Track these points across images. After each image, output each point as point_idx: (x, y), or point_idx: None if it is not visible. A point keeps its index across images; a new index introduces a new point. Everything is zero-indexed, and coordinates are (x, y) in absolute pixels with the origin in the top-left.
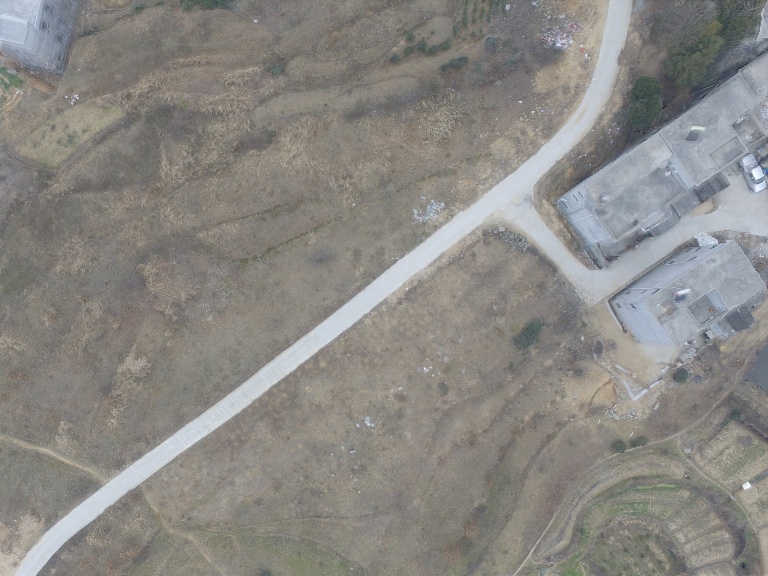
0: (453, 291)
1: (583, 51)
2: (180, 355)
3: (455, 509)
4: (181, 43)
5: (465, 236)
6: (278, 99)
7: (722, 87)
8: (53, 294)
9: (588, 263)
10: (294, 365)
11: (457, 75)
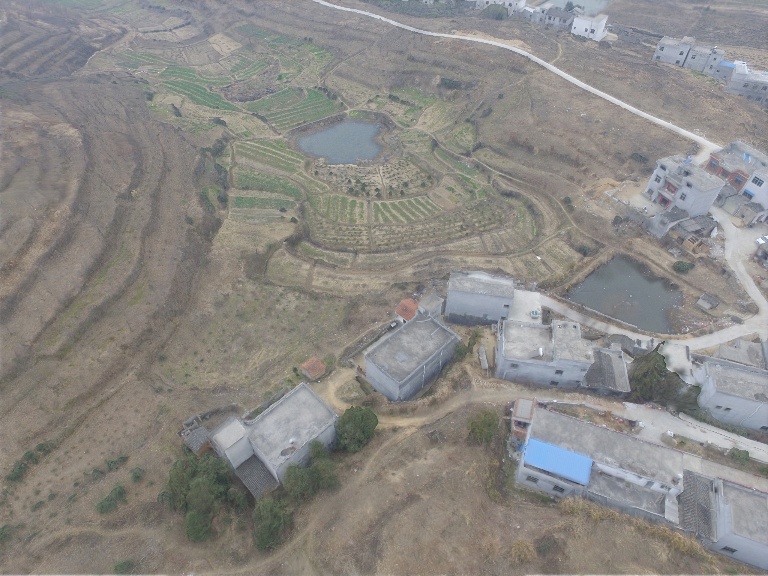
0: (658, 135)
1: None
2: None
3: (535, 140)
4: (754, 116)
5: (690, 138)
6: None
7: None
8: None
9: None
10: None
11: None
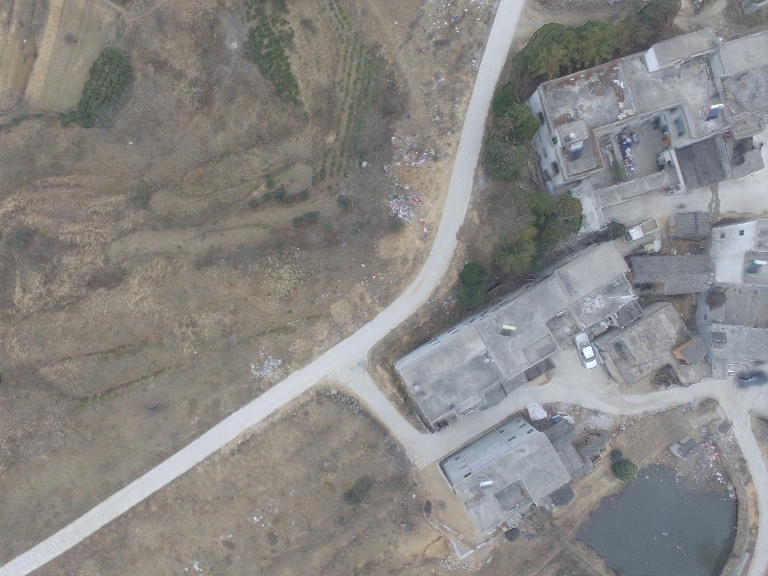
0: (285, 446)
1: (423, 225)
2: (14, 488)
3: None
4: (54, 160)
5: (299, 395)
6: (134, 235)
7: (539, 286)
8: None
9: (420, 427)
10: (126, 506)
11: (306, 231)
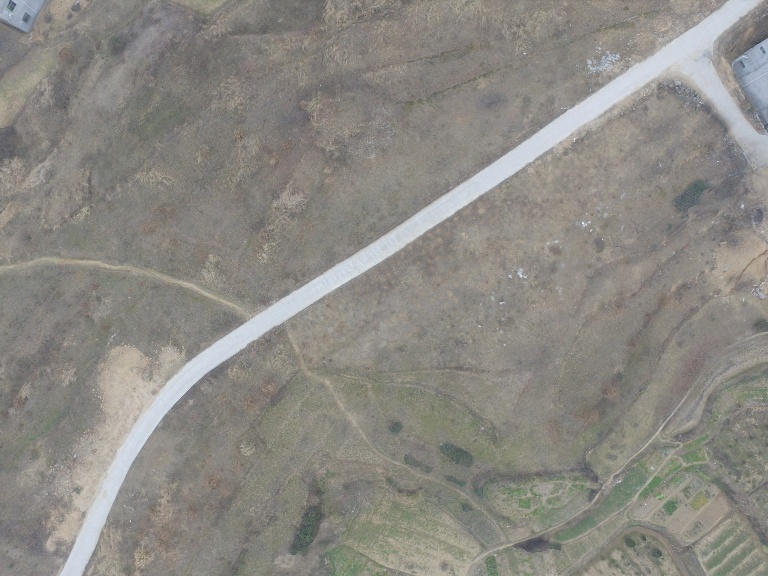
0: (621, 145)
1: None
2: (337, 193)
3: (596, 372)
4: None
5: (639, 88)
6: None
7: None
8: (207, 131)
9: (758, 127)
10: (452, 210)
11: None
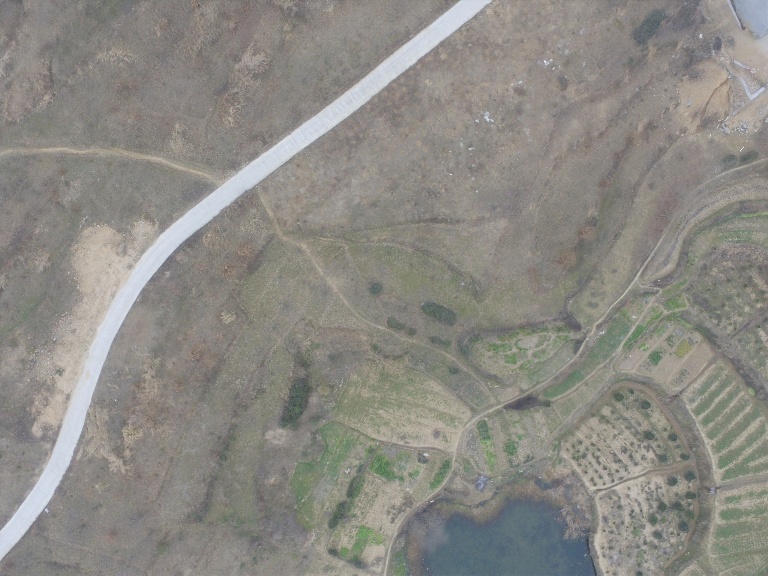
0: None
1: None
2: (299, 51)
3: (570, 215)
4: None
5: None
6: None
7: None
8: (164, 5)
9: None
10: (414, 59)
11: None
